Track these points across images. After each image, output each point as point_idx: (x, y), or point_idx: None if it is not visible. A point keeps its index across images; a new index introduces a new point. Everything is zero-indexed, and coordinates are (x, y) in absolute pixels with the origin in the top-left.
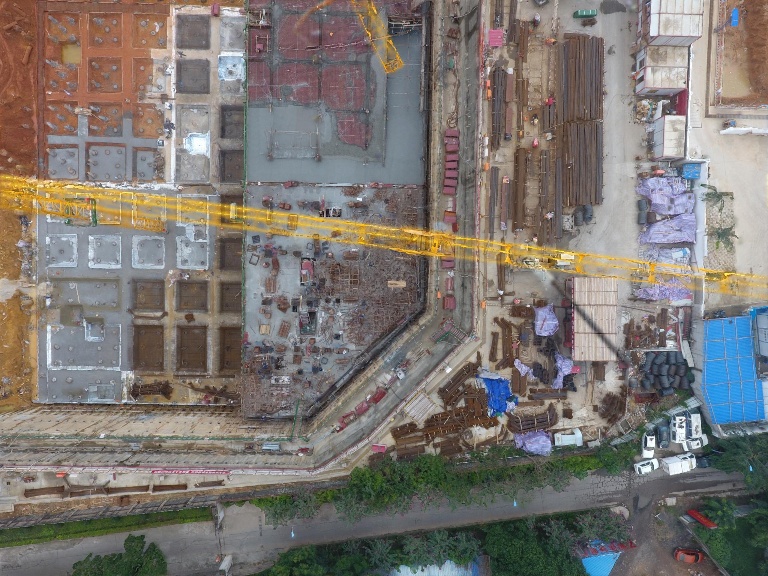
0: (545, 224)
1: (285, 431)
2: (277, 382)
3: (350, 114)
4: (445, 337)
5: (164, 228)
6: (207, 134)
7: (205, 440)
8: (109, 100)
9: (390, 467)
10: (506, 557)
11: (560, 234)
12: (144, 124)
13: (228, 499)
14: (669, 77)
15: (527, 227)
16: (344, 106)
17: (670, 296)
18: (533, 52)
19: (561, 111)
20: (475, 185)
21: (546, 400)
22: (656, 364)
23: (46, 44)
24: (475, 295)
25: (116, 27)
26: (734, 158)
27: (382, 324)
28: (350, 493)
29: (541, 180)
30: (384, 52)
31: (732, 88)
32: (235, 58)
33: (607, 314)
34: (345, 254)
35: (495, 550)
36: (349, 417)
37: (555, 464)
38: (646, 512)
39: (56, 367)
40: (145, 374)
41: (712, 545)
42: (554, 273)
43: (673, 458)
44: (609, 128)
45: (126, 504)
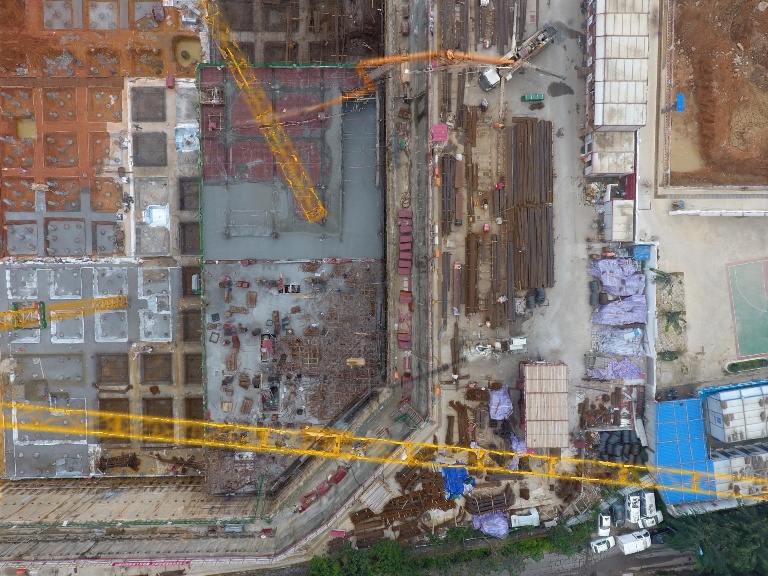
0: (498, 307)
1: (248, 511)
2: (241, 458)
3: (306, 190)
4: (403, 418)
5: (126, 302)
6: (166, 206)
7: (168, 524)
8: (66, 175)
9: (348, 556)
10: None
11: (513, 317)
12: (102, 197)
13: None
14: (616, 162)
15: (480, 311)
16: (300, 182)
17: (623, 376)
18: (482, 137)
19: (511, 195)
20: (427, 271)
21: (503, 481)
22: (610, 444)
23: (0, 120)
24: (430, 380)
25: (71, 101)
26: (684, 238)
27: (342, 401)
28: None
29: (492, 265)
30: (338, 127)
31: (683, 162)
32: (192, 129)
33: (558, 401)
34: (305, 330)
35: None
36: (310, 498)
37: (510, 550)
38: None
39: (23, 442)
40: (112, 447)
41: None
42: (508, 355)
43: (629, 536)
44: (559, 210)
45: None
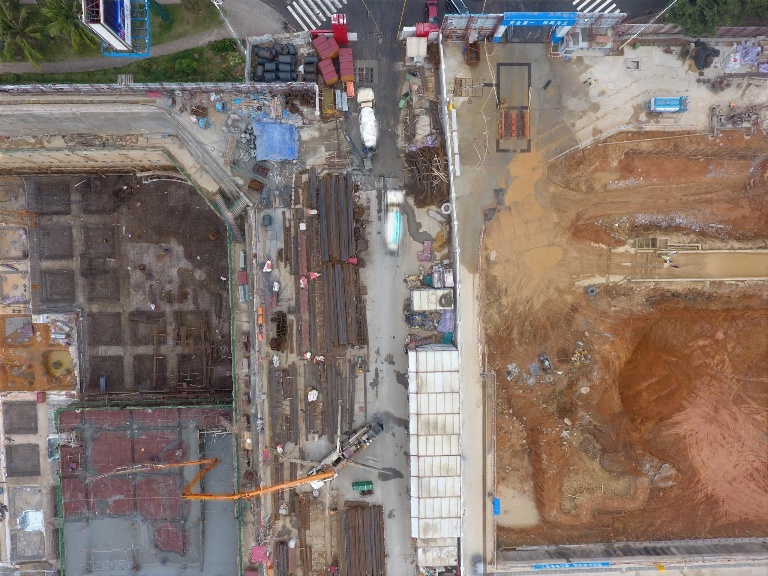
0: None
1: None
2: None
3: (166, 523)
4: None
5: None
6: (41, 511)
7: None
8: None
9: None
10: None
11: None
12: None
13: None
14: (440, 556)
15: None
16: (160, 515)
17: None
18: (315, 520)
19: (345, 574)
20: None
21: None
22: None
23: None
24: None
25: None
26: None
27: None
28: None
29: None
30: None
31: (521, 518)
32: None
33: None
34: None
35: None
36: None
37: None
38: None
39: None
40: None
41: None
42: None
43: None
44: None
45: None
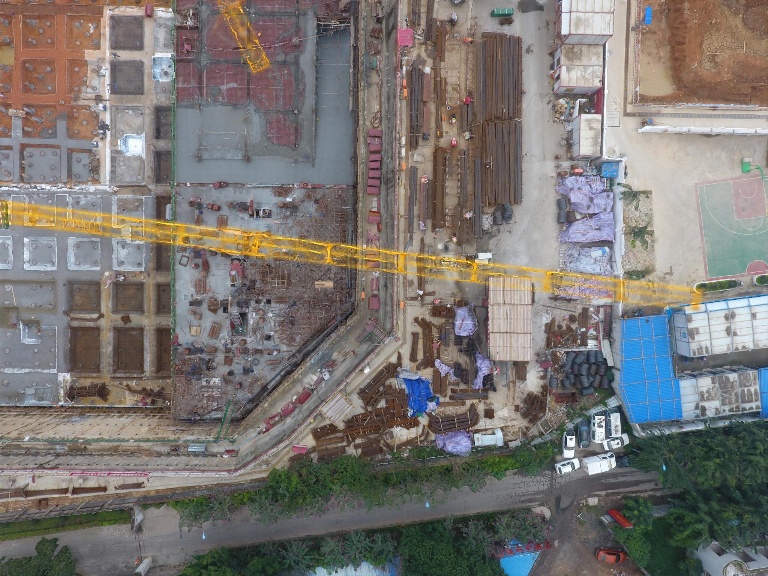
0: (465, 224)
1: (213, 433)
2: (208, 383)
3: (279, 114)
4: (369, 337)
5: (99, 230)
6: (142, 135)
7: (131, 442)
8: (43, 101)
9: (307, 468)
10: (416, 558)
11: (480, 234)
12: (79, 125)
13: (145, 501)
14: (584, 76)
15: (447, 227)
16: (273, 106)
17: (590, 295)
18: (451, 51)
19: (480, 110)
20: (394, 185)
21: (467, 400)
22: (576, 363)
23: None
24: (395, 295)
25: (50, 28)
26: (653, 156)
27: (310, 325)
28: (265, 495)
29: (460, 179)
30: (313, 52)
31: (655, 86)
32: (170, 59)
33: (522, 314)
34: (275, 255)
35: (406, 551)
36: (274, 418)
37: (471, 464)
38: (568, 512)
39: None
40: (81, 376)
41: (630, 545)
42: None
43: (593, 458)
44: (528, 127)
45: (44, 507)
